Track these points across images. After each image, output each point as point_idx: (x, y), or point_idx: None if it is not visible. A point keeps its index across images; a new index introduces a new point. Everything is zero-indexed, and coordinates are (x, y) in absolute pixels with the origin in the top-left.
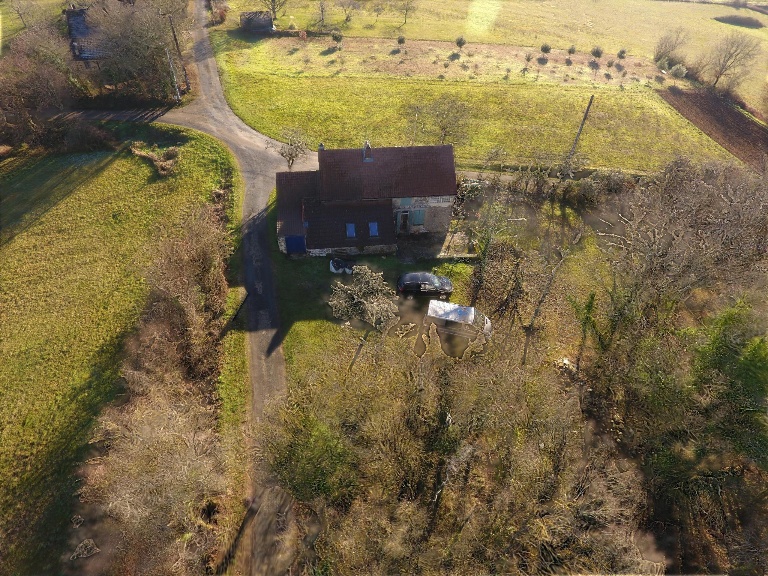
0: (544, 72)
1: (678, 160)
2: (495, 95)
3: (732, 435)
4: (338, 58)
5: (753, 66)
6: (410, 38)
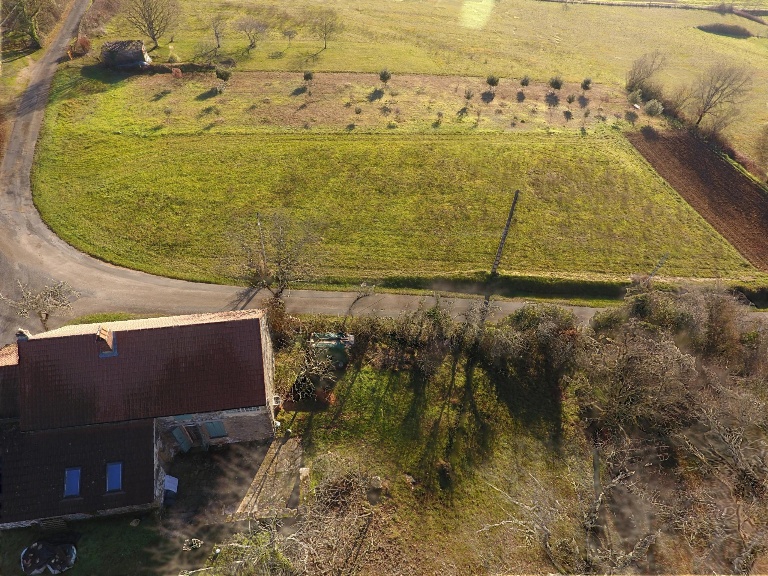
0: (487, 113)
1: (640, 296)
2: (416, 153)
3: None
4: (219, 103)
5: (744, 103)
6: (324, 70)
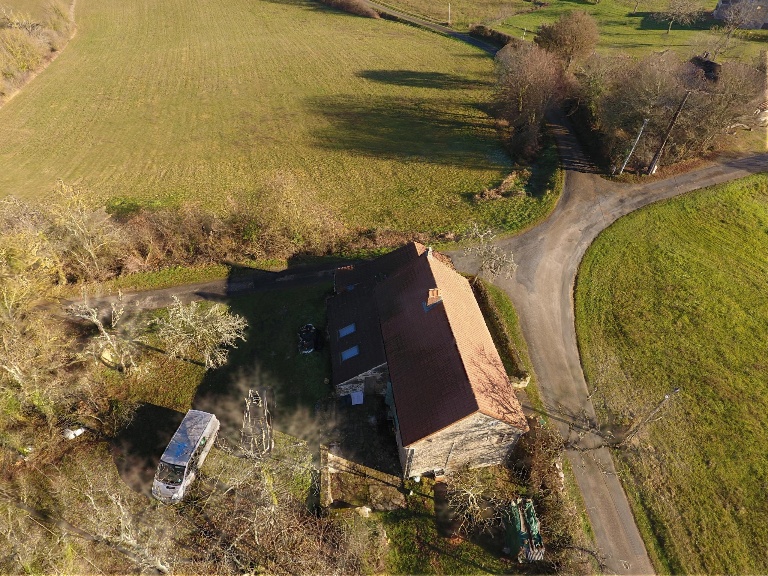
0: None
1: None
2: None
3: None
4: None
5: None
6: None
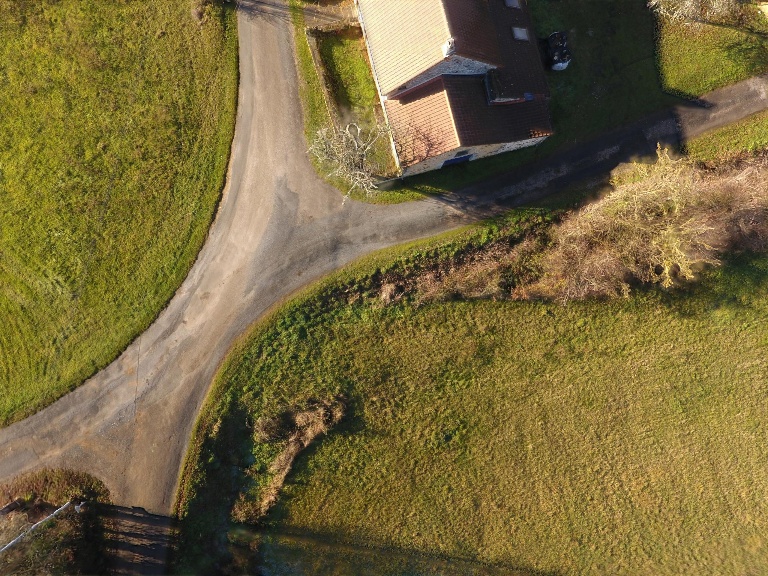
0: None
1: None
2: None
3: None
4: None
5: None
6: None
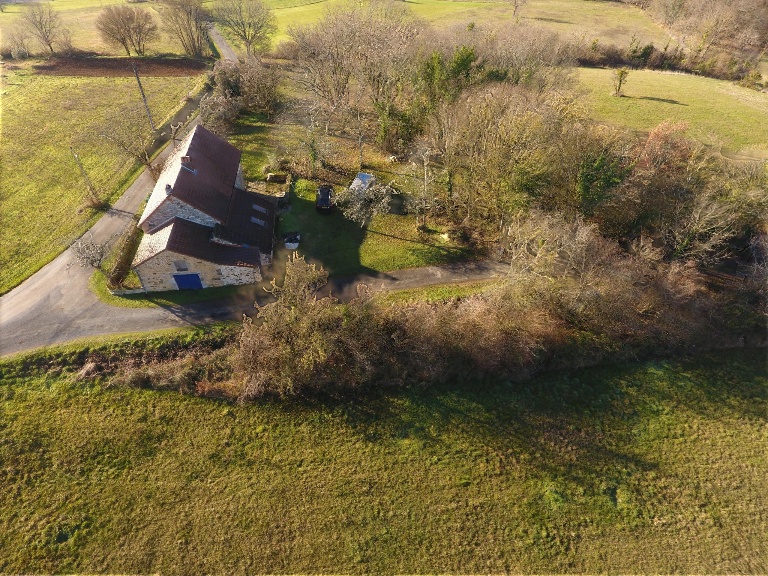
0: None
1: (220, 72)
2: None
3: (491, 79)
4: None
5: (61, 25)
6: None
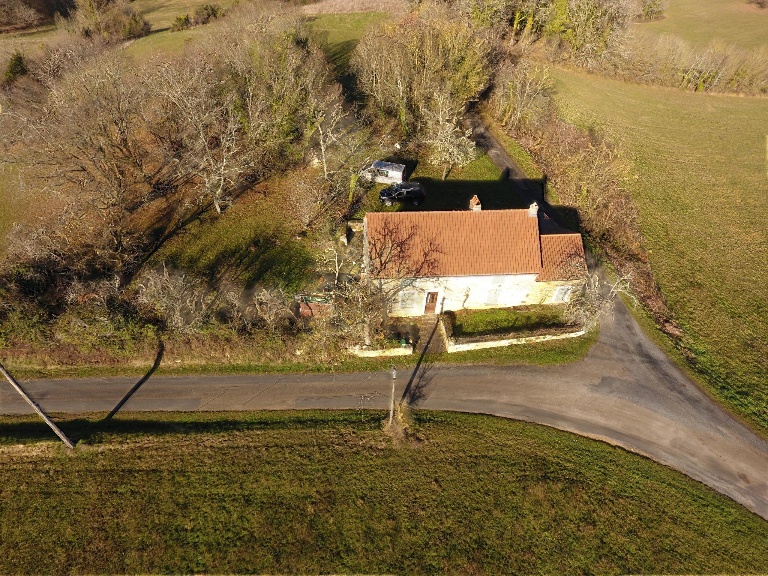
0: None
1: None
2: None
3: None
4: None
5: None
6: None
